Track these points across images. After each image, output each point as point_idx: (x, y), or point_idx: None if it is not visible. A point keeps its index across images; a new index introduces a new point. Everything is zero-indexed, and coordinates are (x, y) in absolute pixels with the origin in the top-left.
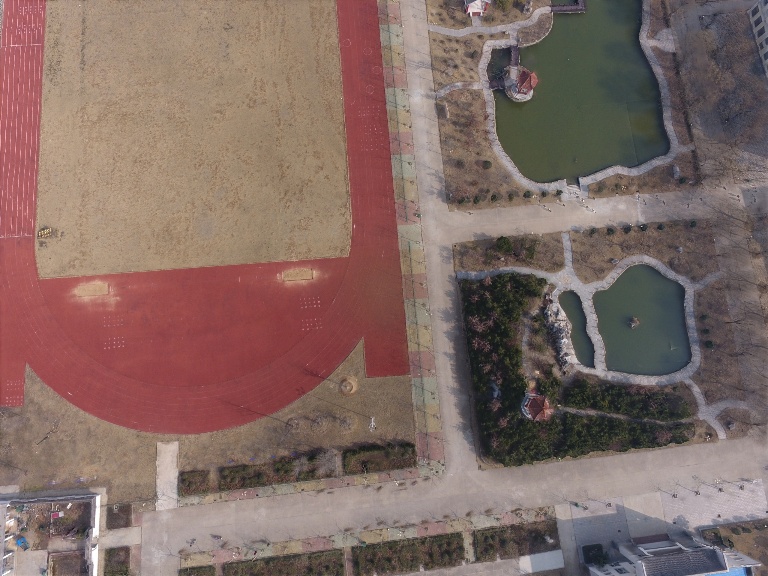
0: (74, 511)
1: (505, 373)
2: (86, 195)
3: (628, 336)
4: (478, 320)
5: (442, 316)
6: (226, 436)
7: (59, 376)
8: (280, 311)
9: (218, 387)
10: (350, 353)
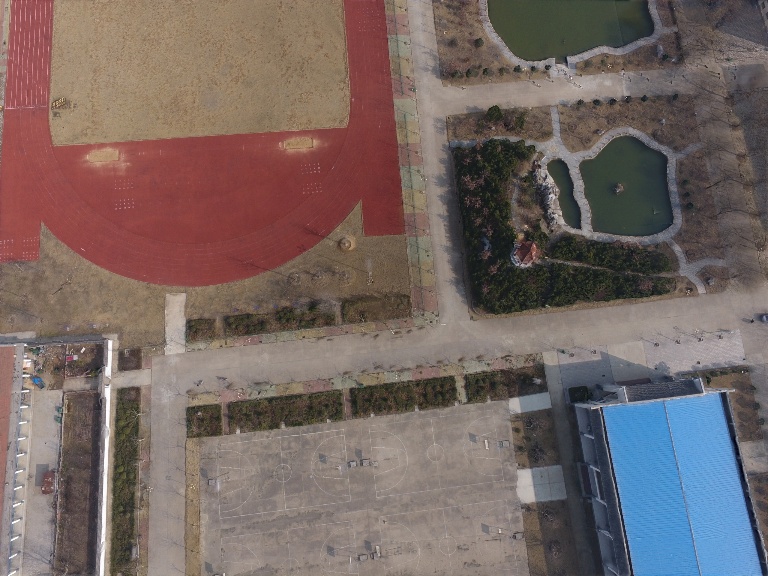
0: (87, 355)
1: (495, 225)
2: (97, 70)
3: (613, 201)
4: (470, 179)
5: (436, 181)
6: (231, 288)
7: (73, 233)
8: (282, 176)
9: (223, 244)
10: (348, 214)
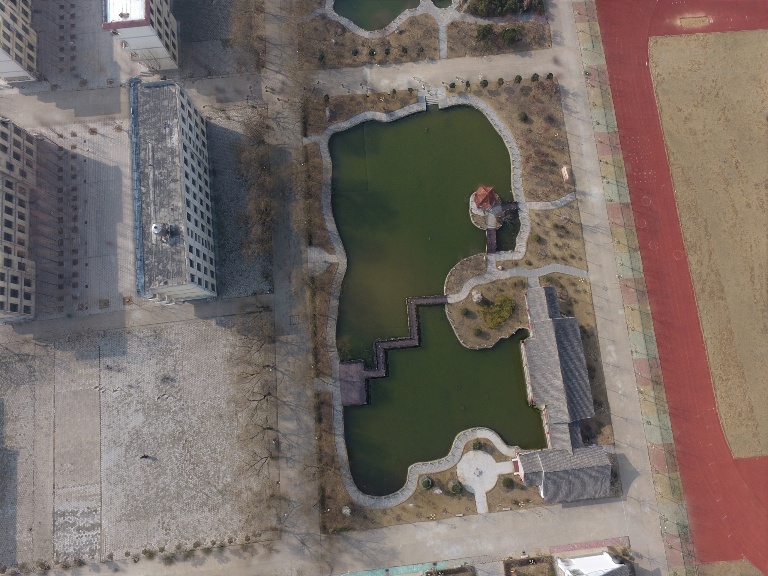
0: None
1: None
2: None
3: None
4: None
5: None
6: None
7: None
8: None
9: None
10: None
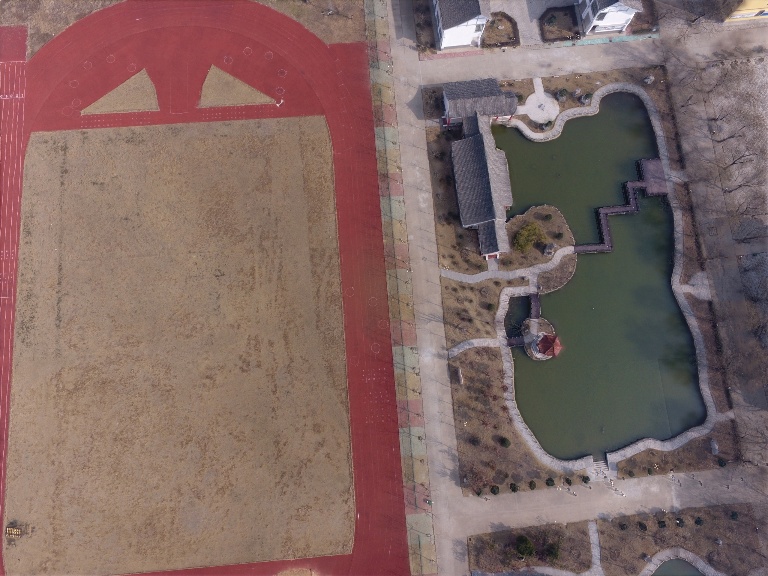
0: None
1: None
2: (60, 481)
3: None
4: None
5: None
6: None
7: None
8: None
9: None
10: None
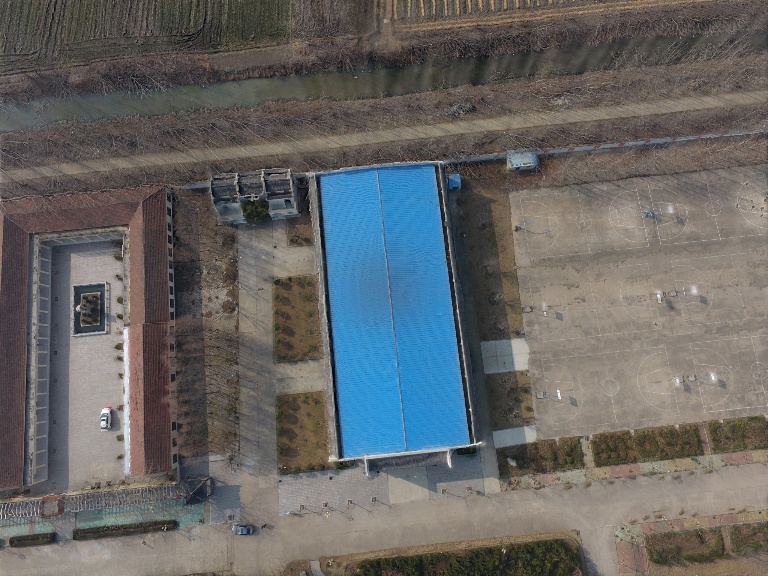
0: None
1: None
2: None
3: None
4: None
5: None
6: None
7: None
8: None
9: None
10: None
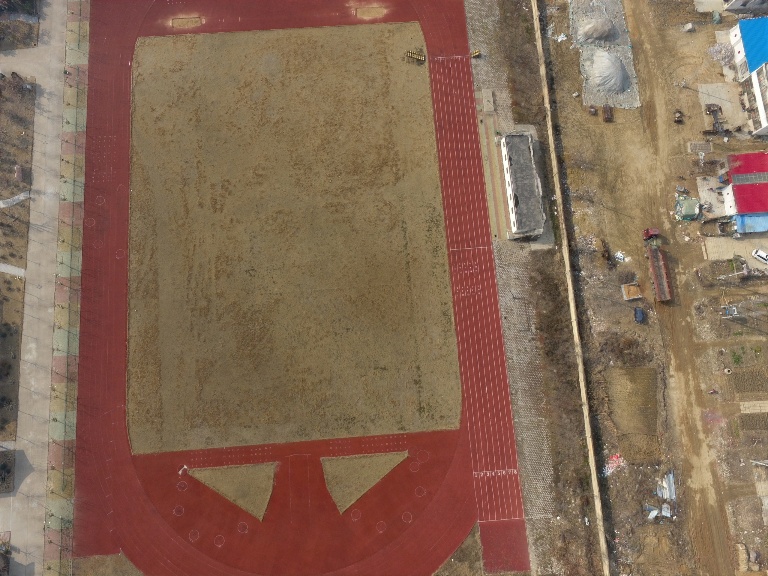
0: None
1: None
2: (385, 93)
3: None
4: None
5: None
6: None
7: None
8: None
9: None
10: None
